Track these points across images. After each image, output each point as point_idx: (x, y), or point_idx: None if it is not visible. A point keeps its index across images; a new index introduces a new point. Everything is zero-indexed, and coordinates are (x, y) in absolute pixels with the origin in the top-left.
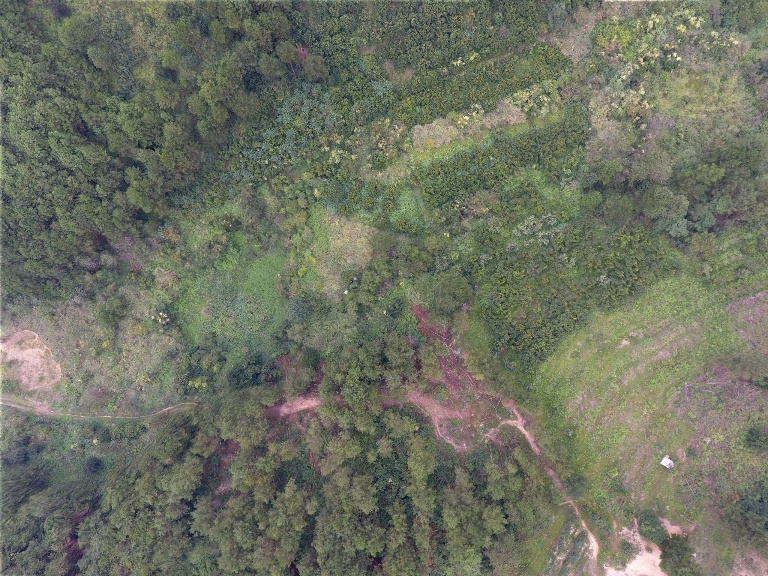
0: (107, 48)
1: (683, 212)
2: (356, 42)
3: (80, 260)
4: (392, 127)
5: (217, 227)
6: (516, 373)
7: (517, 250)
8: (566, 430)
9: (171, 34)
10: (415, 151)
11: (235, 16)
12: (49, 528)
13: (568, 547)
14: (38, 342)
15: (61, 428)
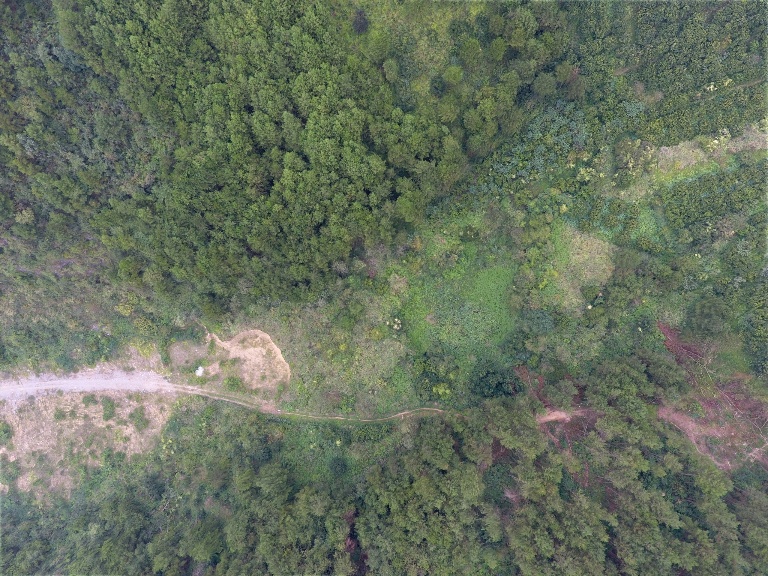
0: (397, 61)
1: None
2: (616, 63)
3: (338, 265)
4: (642, 148)
5: (455, 237)
6: None
7: None
8: None
9: (449, 49)
10: (658, 171)
11: (522, 35)
12: (333, 527)
13: None
14: (260, 341)
15: (295, 427)
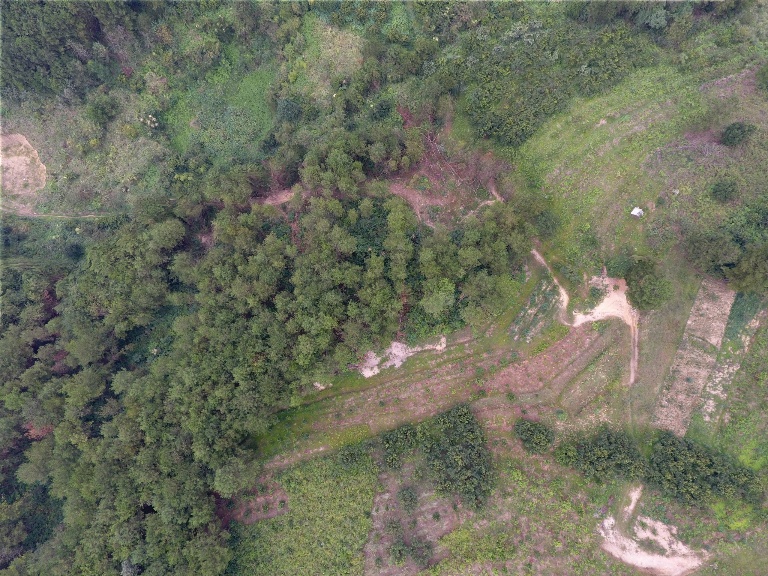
0: None
1: (662, 1)
2: None
3: (72, 44)
4: None
5: (210, 34)
6: (497, 154)
7: (503, 51)
8: (542, 193)
9: None
10: None
11: None
12: (27, 278)
13: (539, 302)
14: (24, 150)
15: (43, 224)
